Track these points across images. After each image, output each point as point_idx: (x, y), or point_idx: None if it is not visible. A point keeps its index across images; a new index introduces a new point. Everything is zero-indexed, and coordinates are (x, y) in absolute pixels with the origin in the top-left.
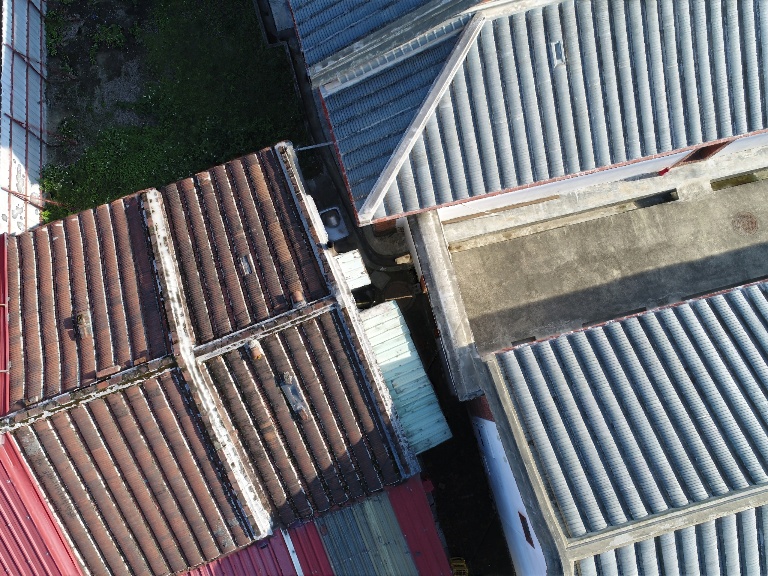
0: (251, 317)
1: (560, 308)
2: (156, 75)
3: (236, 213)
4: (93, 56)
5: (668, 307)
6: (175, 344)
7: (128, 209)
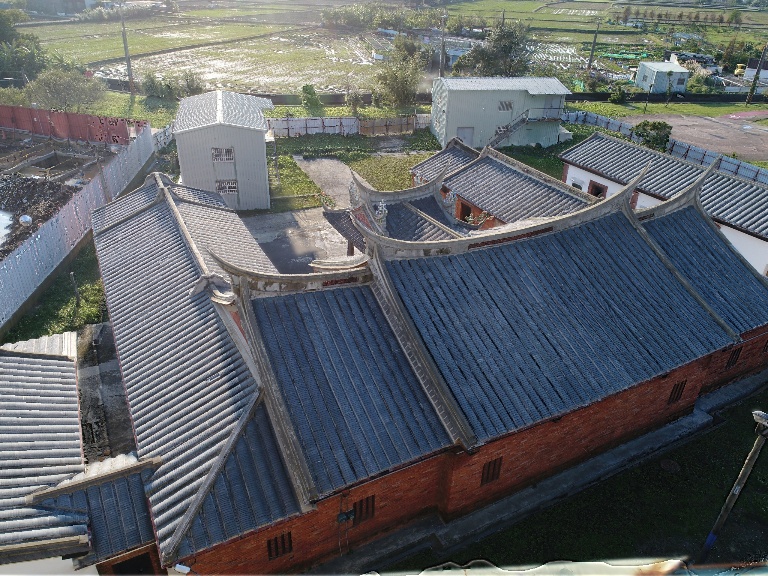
0: None
1: None
2: None
3: None
4: None
5: (760, 234)
6: None
7: None
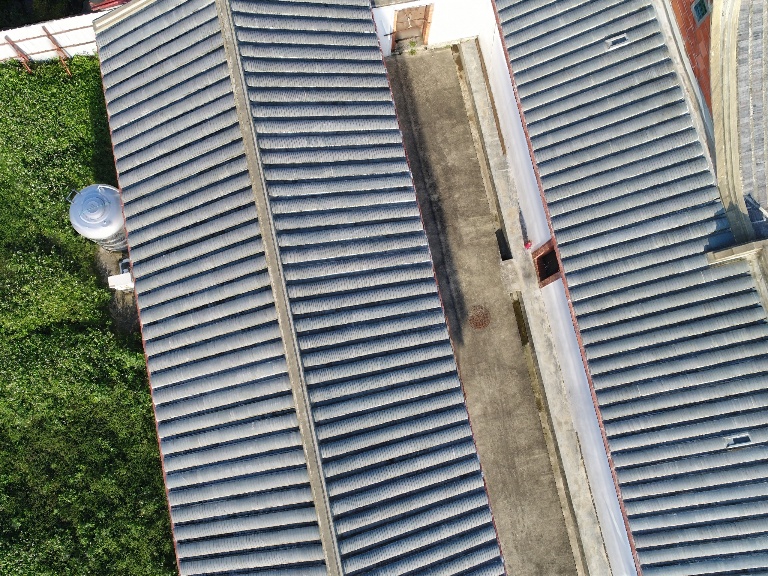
0: None
1: (406, 147)
2: None
3: None
4: None
5: None
6: None
7: None
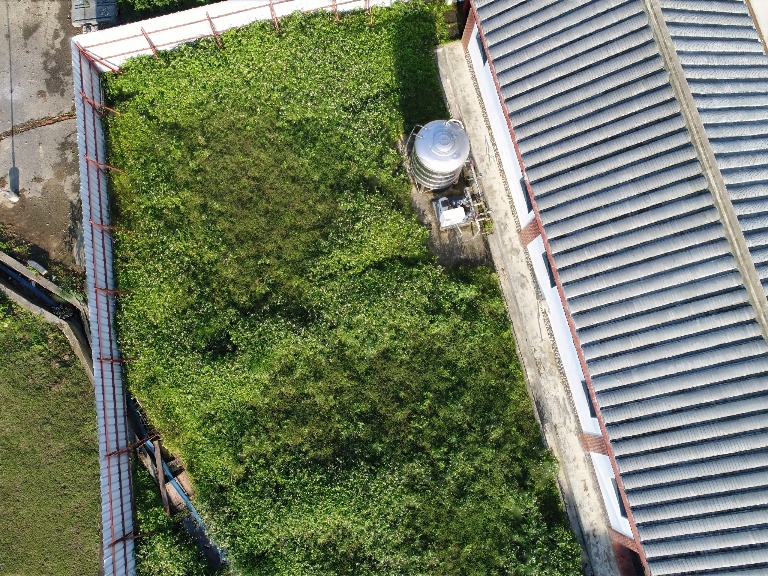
0: None
1: None
2: None
3: None
4: None
5: None
6: None
7: None
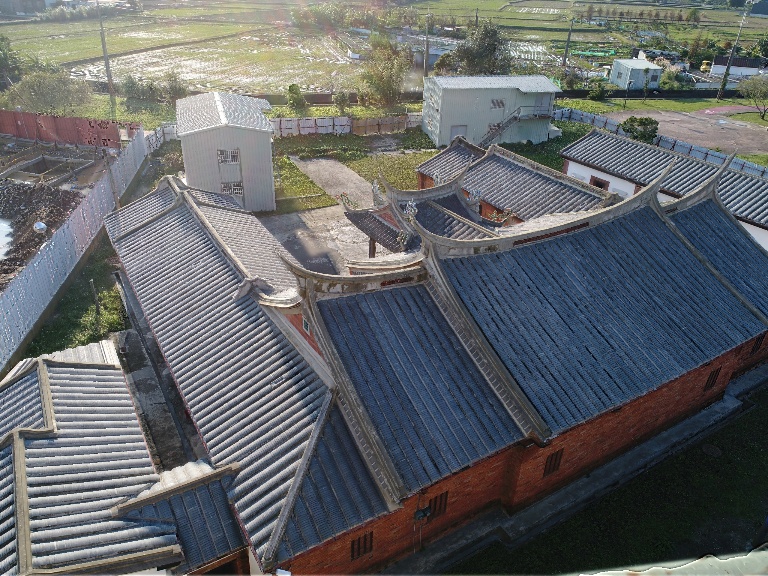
0: None
1: None
2: None
3: None
4: None
5: None
6: None
7: None
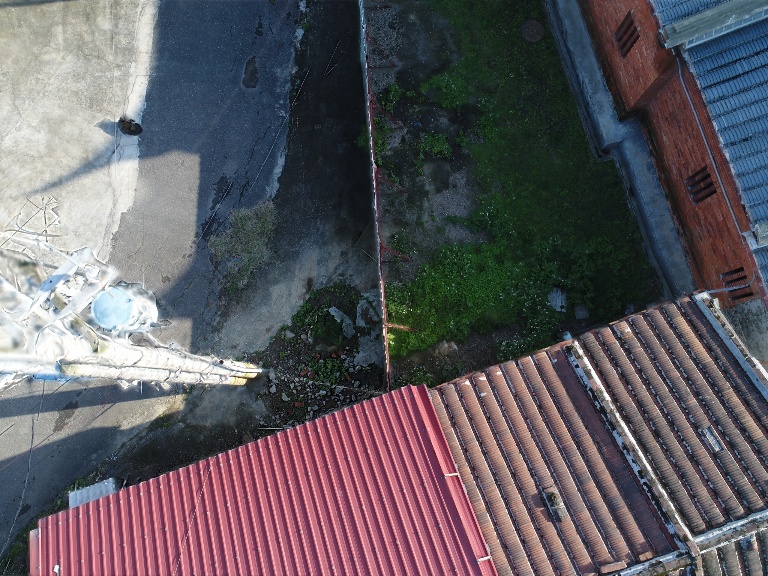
0: (740, 503)
1: None
2: (487, 189)
3: (678, 375)
4: (419, 166)
5: None
6: (689, 541)
7: (556, 364)
